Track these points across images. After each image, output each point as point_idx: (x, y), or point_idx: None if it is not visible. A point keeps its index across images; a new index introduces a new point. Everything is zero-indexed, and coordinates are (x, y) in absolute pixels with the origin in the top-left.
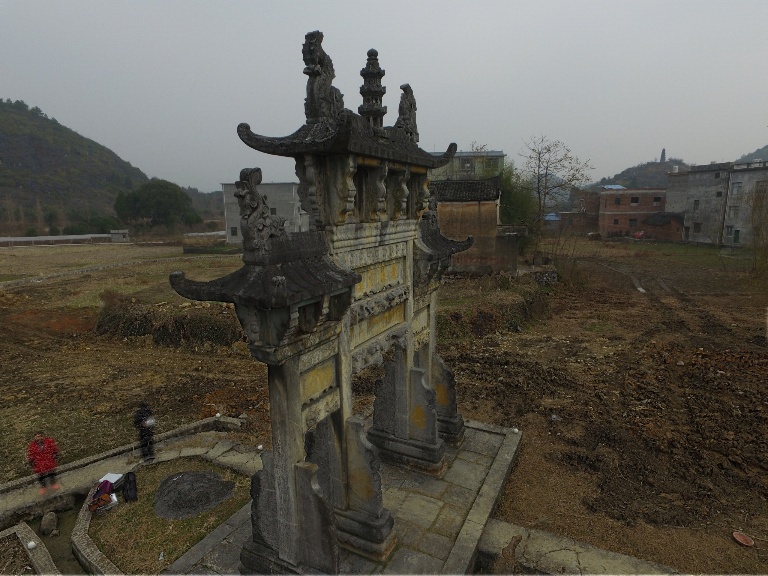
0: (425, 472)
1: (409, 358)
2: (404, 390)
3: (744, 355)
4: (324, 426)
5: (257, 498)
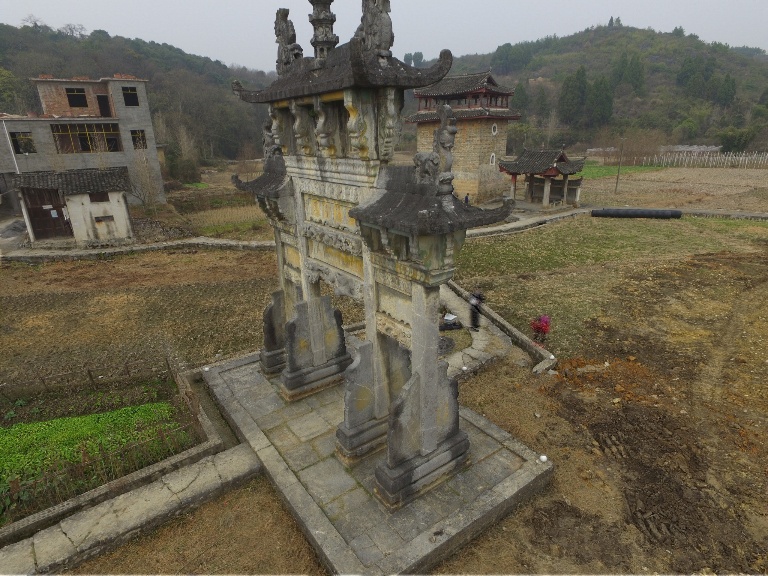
0: None
1: (368, 327)
2: None
3: None
4: None
5: None
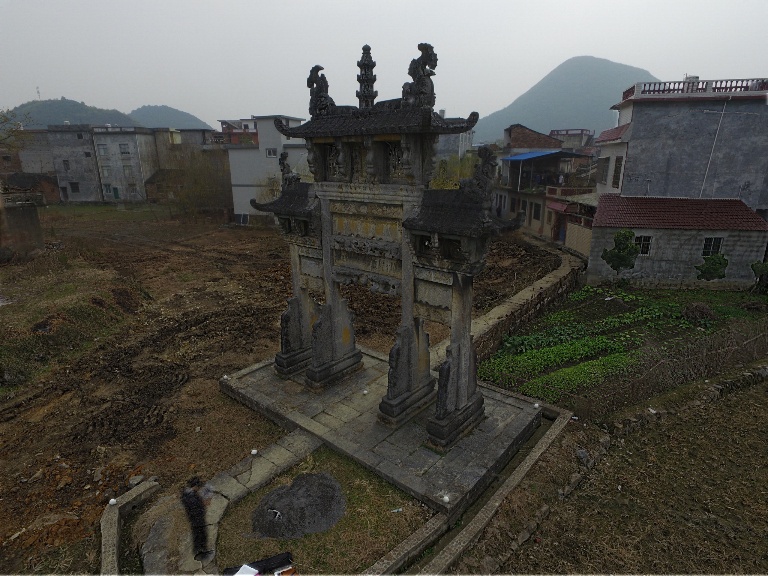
0: (357, 372)
1: None
2: (340, 319)
3: None
4: (406, 337)
5: (447, 384)
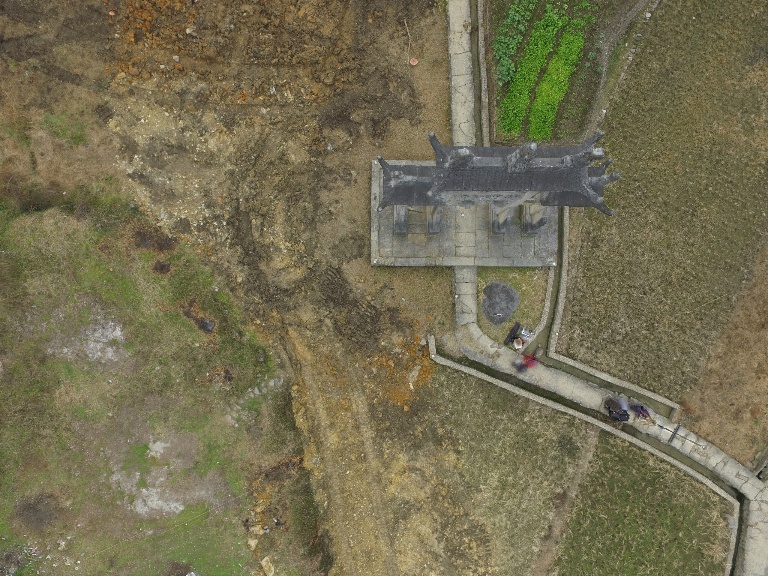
0: None
1: None
2: None
3: (145, 4)
4: None
5: None
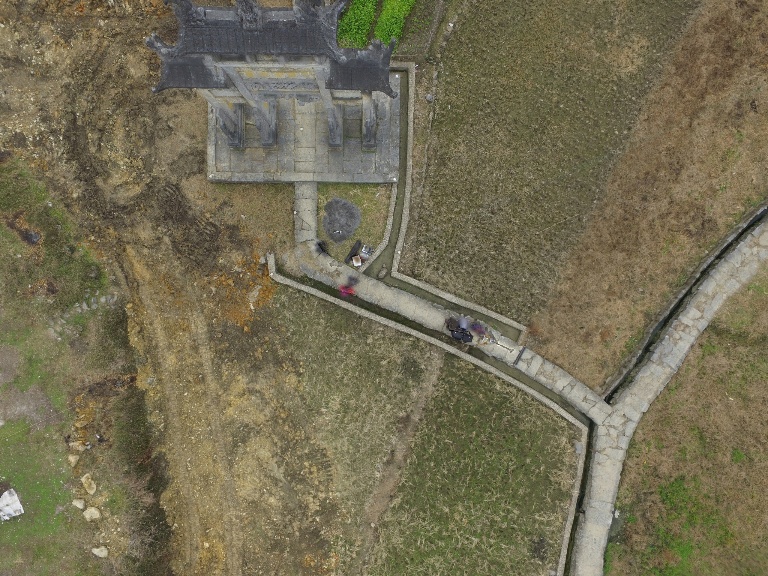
0: None
1: None
2: (263, 106)
3: None
4: None
5: None
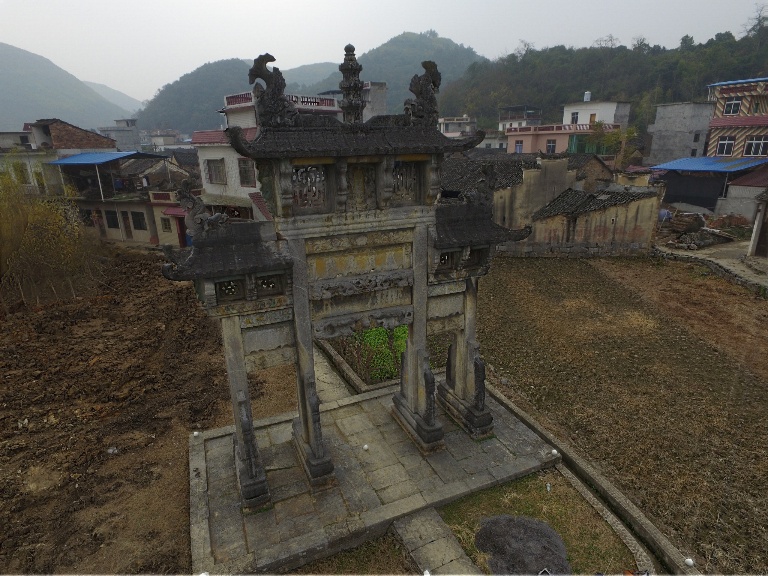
0: None
1: None
2: None
3: None
4: None
5: None
